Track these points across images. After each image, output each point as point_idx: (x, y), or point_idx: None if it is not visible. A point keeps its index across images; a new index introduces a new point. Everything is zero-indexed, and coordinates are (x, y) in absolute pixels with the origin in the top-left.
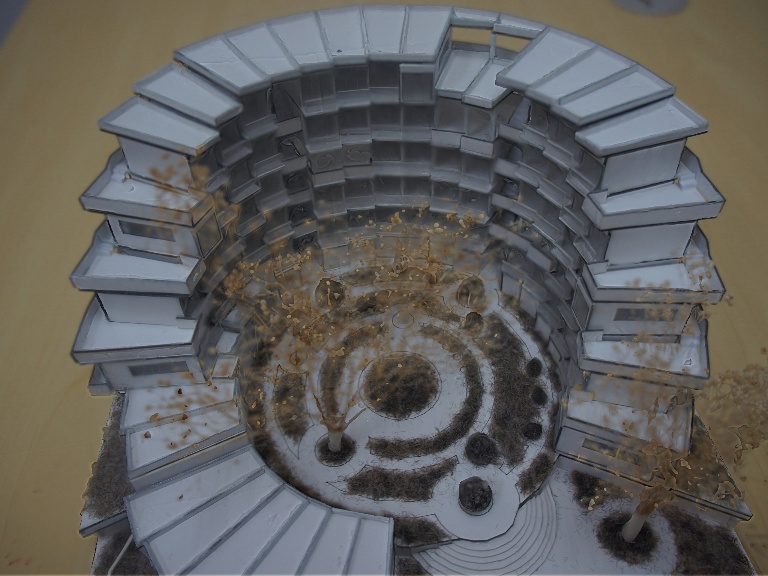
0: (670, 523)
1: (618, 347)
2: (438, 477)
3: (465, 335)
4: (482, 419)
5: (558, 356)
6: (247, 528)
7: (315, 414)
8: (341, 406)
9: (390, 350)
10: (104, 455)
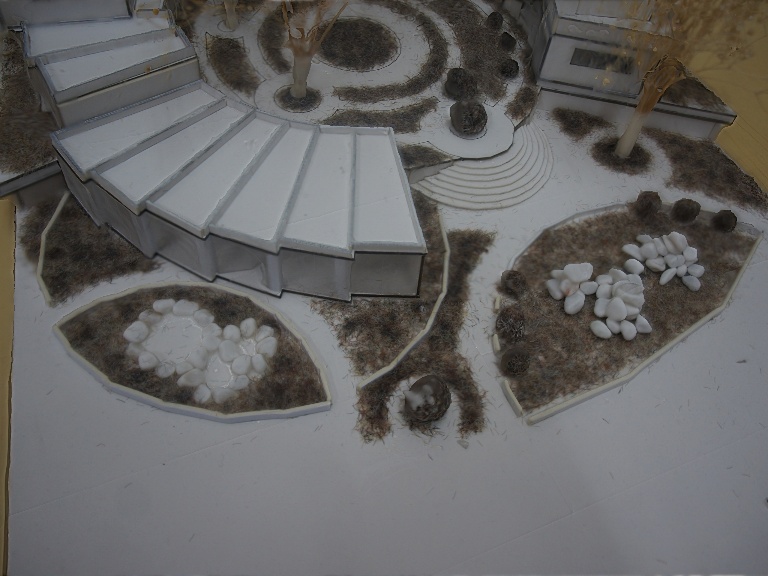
0: (657, 142)
1: None
2: (422, 113)
3: (413, 1)
4: (453, 66)
5: (519, 5)
6: (221, 154)
7: (264, 71)
8: (293, 63)
9: None
10: (4, 114)
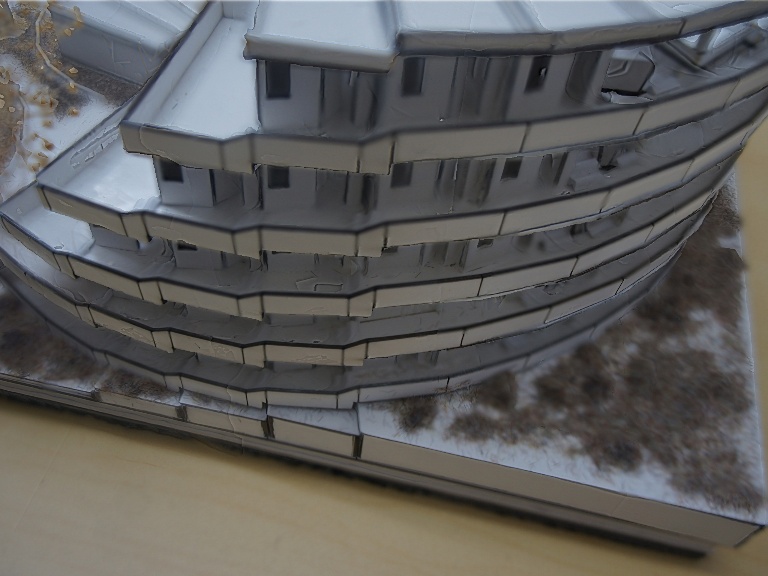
0: None
1: None
2: None
3: None
4: None
5: None
6: None
7: None
8: None
9: None
10: None
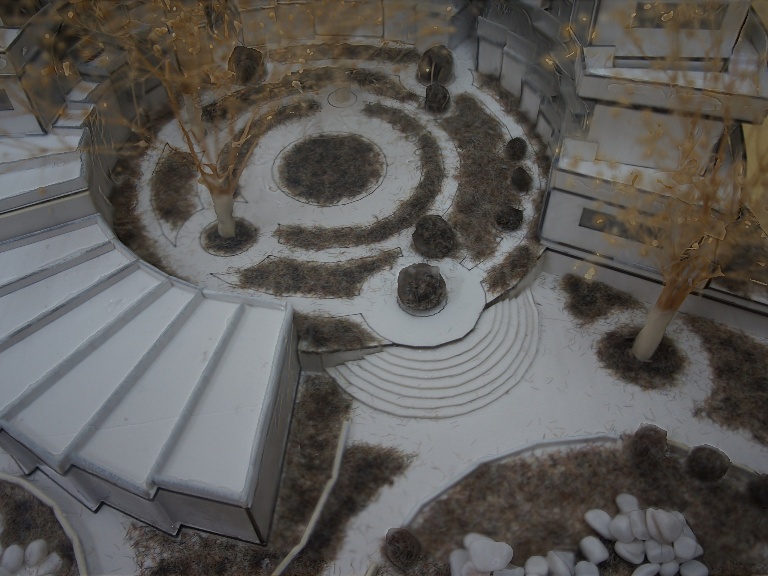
0: (703, 339)
1: (636, 73)
2: (371, 270)
3: (424, 115)
4: (440, 207)
5: (549, 132)
6: (75, 315)
7: (207, 197)
8: (245, 189)
9: (321, 130)
10: None
